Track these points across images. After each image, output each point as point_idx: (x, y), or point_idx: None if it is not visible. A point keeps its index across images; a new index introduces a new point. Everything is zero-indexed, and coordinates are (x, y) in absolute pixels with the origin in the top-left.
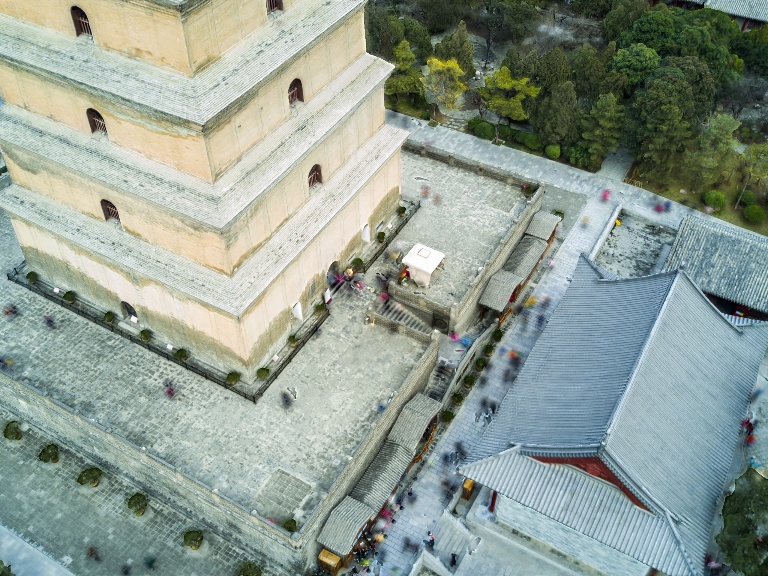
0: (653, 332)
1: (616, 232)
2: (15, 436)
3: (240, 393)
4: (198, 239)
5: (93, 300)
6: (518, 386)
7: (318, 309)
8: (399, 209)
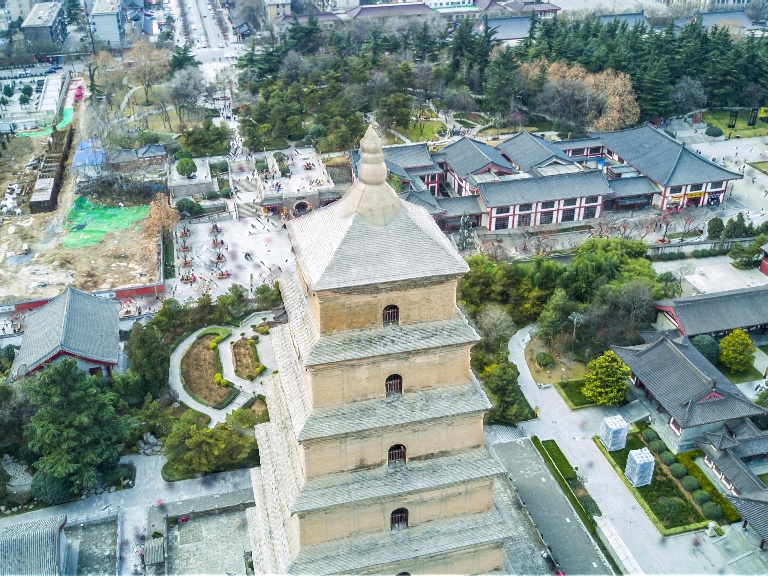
0: None
1: None
2: None
3: None
4: None
5: None
6: None
7: None
8: None
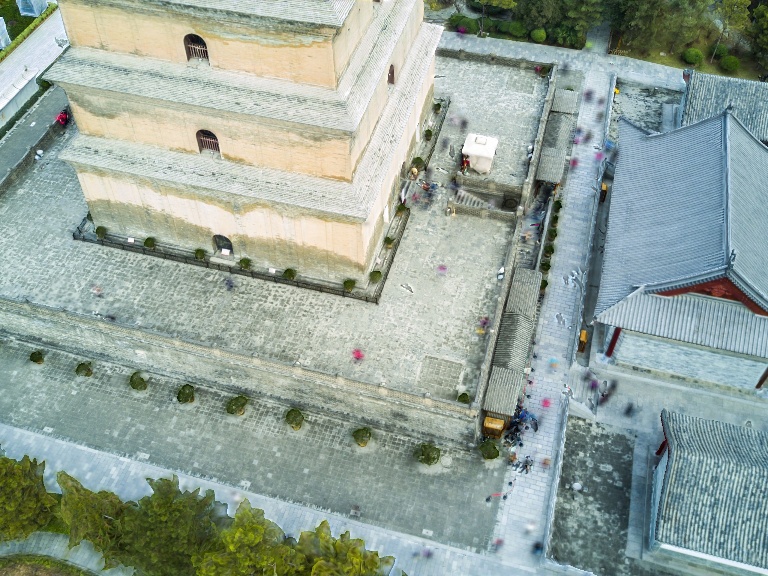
0: (729, 166)
1: (618, 100)
2: (143, 386)
3: (361, 298)
4: (317, 150)
5: (177, 242)
6: (613, 240)
7: (401, 209)
8: (435, 106)
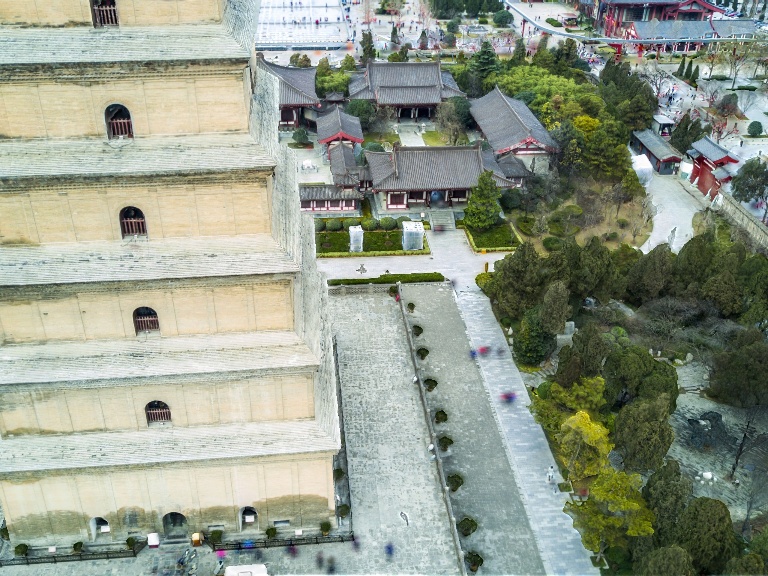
0: None
1: None
2: None
3: None
4: None
5: None
6: None
7: (127, 542)
8: (323, 523)
